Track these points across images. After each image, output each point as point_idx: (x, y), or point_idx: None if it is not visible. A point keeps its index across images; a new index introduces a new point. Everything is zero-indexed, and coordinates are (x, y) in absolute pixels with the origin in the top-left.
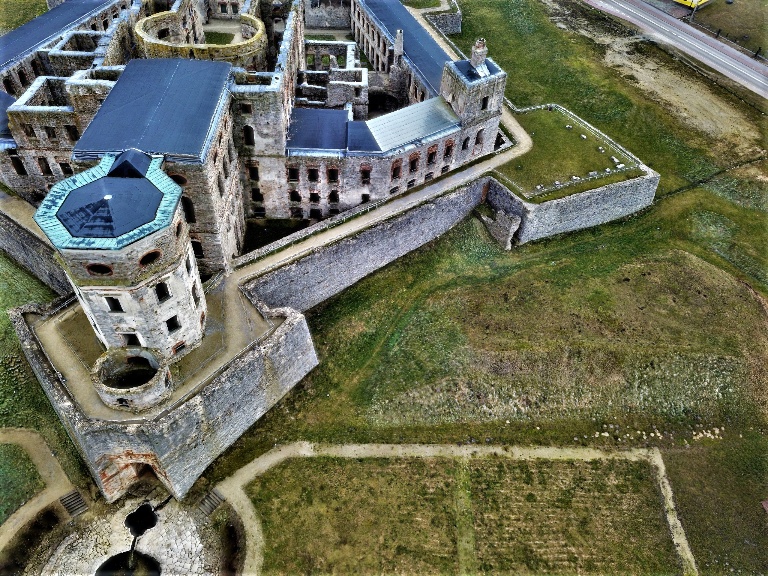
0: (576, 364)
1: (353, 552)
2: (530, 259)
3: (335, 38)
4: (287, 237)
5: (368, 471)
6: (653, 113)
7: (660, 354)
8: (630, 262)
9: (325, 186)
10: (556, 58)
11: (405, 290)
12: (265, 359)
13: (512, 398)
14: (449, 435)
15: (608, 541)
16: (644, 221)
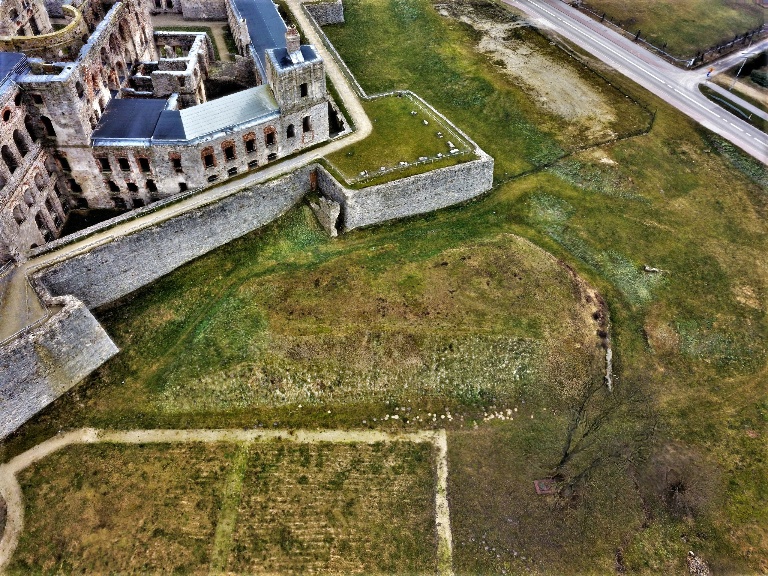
0: (375, 348)
1: (109, 535)
2: (355, 245)
3: (211, 29)
4: (92, 227)
5: (146, 456)
6: (512, 98)
7: (460, 337)
8: (456, 246)
9: (139, 175)
10: (430, 45)
11: (221, 278)
12: (36, 347)
13: (306, 382)
14: (237, 420)
15: (369, 521)
16: (481, 206)
